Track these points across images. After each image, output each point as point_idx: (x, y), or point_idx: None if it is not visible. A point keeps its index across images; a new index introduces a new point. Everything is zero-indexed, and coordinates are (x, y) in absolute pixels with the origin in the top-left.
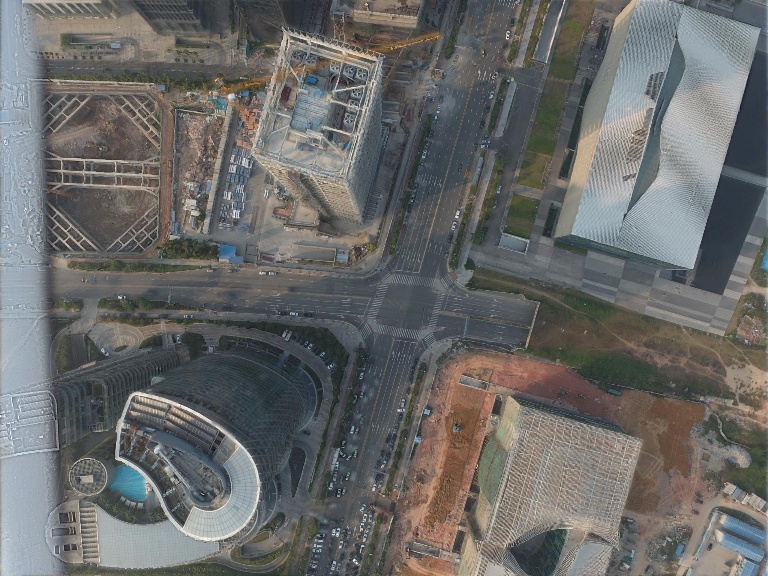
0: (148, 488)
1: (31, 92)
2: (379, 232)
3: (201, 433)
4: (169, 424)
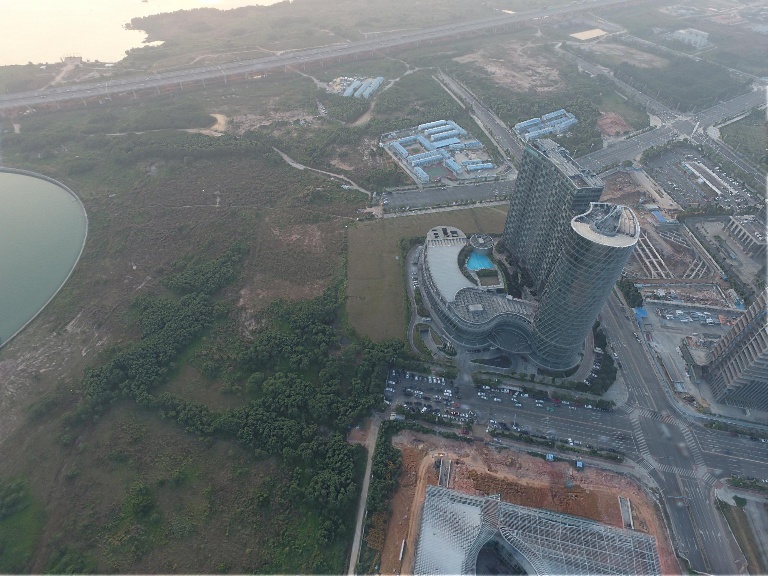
0: (476, 269)
1: (676, 226)
2: (717, 415)
3: (628, 229)
4: (622, 219)
